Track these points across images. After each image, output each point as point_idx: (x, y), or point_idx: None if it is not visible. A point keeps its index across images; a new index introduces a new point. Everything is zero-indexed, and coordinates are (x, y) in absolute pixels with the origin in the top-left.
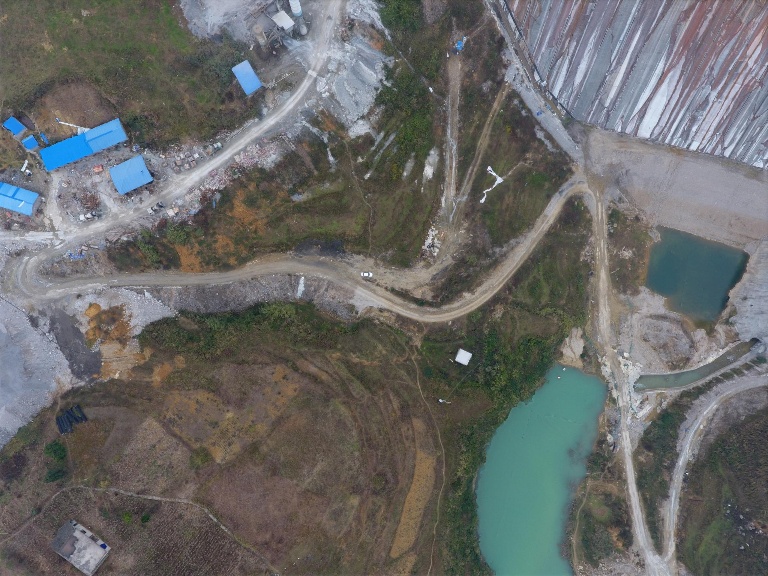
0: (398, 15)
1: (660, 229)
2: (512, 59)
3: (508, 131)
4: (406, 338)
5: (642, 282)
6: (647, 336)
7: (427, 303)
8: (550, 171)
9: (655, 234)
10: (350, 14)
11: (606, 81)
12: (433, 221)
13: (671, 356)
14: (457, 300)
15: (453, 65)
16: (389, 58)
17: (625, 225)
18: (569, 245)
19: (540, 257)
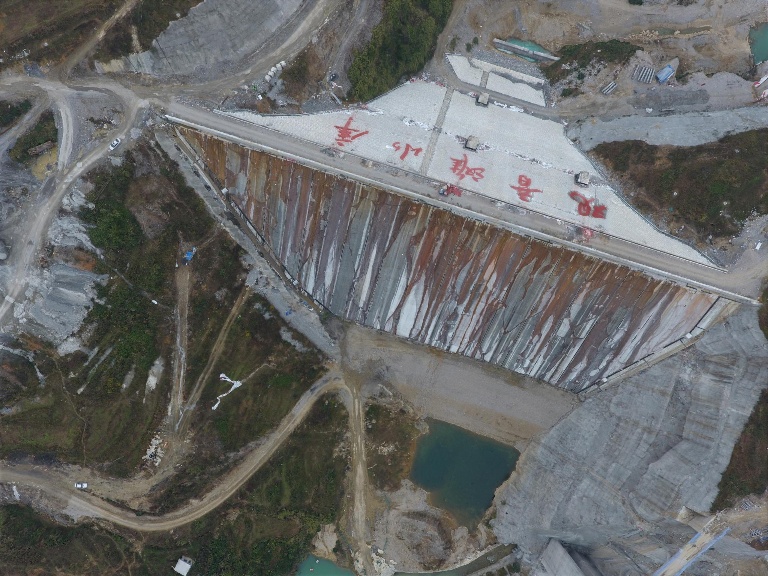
0: (109, 236)
1: (430, 420)
2: (255, 263)
3: (248, 335)
4: (126, 545)
5: (406, 475)
6: (401, 535)
7: (146, 513)
8: (296, 372)
9: (423, 426)
10: (51, 240)
11: (355, 286)
12: (157, 430)
13: (424, 557)
14: (183, 507)
15: (182, 275)
16: (102, 276)
17: (388, 418)
18: (319, 443)
19: (283, 458)
